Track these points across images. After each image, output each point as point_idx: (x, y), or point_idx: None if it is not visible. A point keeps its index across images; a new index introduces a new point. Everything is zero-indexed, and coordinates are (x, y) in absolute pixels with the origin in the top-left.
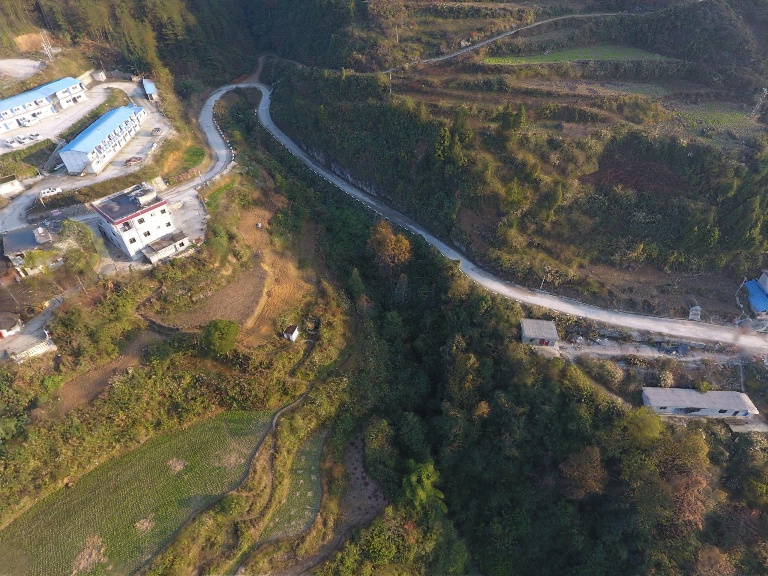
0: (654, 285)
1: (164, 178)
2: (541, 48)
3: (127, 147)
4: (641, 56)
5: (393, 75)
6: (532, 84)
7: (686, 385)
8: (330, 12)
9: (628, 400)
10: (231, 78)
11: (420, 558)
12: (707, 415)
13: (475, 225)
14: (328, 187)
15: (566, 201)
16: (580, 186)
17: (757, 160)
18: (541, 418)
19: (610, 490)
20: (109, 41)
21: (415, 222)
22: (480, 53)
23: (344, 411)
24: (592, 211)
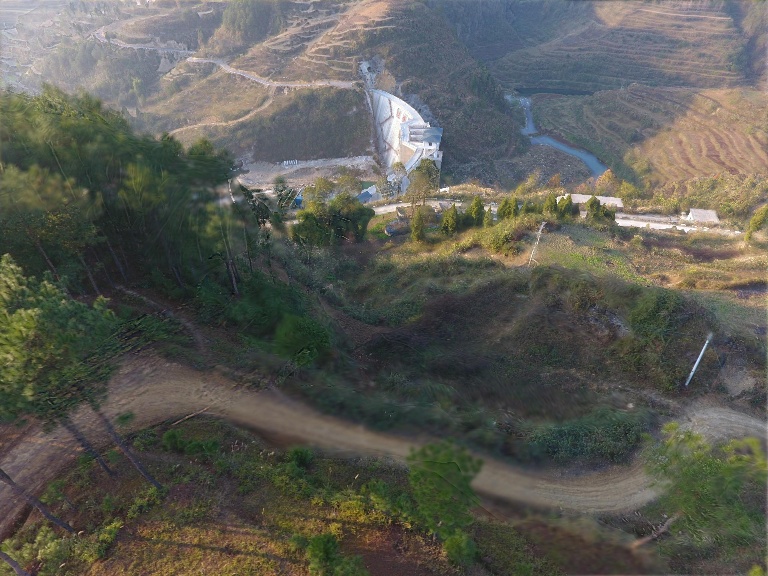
0: None
1: None
2: None
3: None
4: None
5: None
6: None
7: None
8: None
9: None
10: None
11: None
12: None
13: None
14: None
15: None
16: None
17: None
18: None
19: None
20: None
21: None
22: None
23: None
24: None
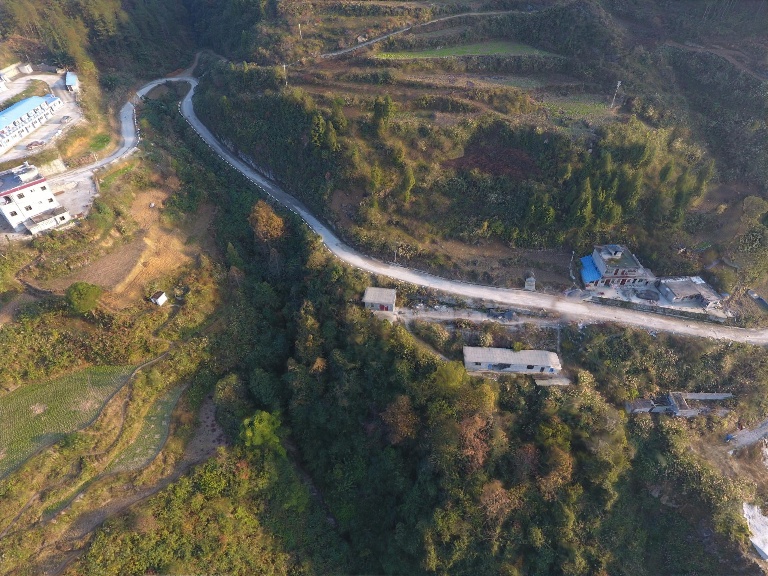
0: (497, 259)
1: (65, 161)
2: (432, 44)
3: (34, 133)
4: None
5: (291, 68)
6: (417, 77)
7: (505, 345)
8: (248, 10)
9: (451, 358)
10: (166, 72)
11: (259, 496)
12: (518, 371)
13: (343, 205)
14: (231, 172)
15: (426, 183)
16: (442, 170)
17: (601, 146)
18: (369, 372)
19: (420, 434)
20: (40, 36)
21: (302, 204)
22: (373, 48)
23: (204, 368)
24: (451, 193)
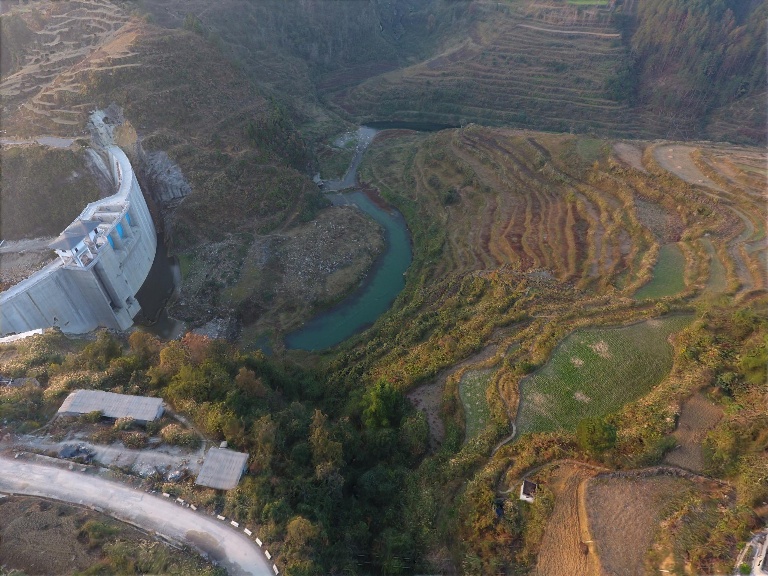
0: (2, 534)
1: None
2: None
3: None
4: None
5: None
6: None
7: (104, 424)
8: None
9: (173, 420)
10: None
11: None
12: None
13: None
14: None
15: None
16: None
17: None
18: None
19: None
20: None
21: None
22: None
23: None
24: None
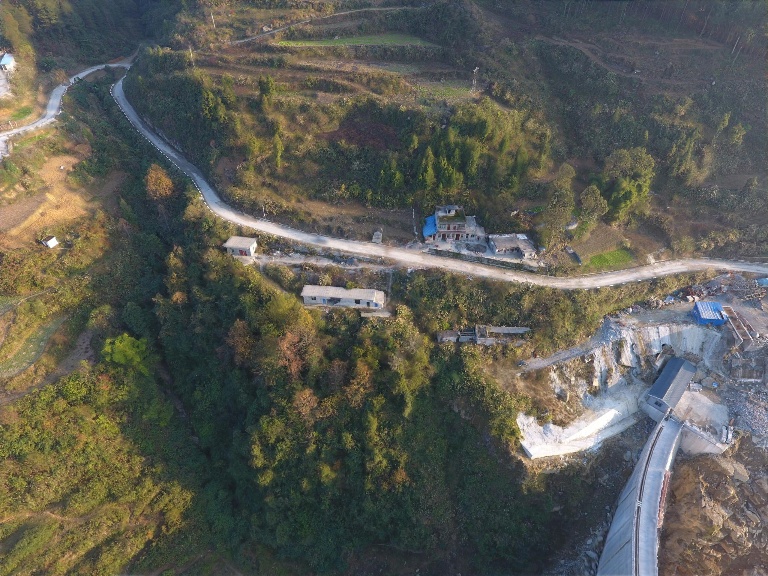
0: (351, 216)
1: None
2: (330, 34)
3: None
4: (412, 43)
5: (200, 53)
6: (309, 62)
7: (342, 285)
8: (175, 2)
9: None
10: (108, 59)
11: (123, 408)
12: (348, 306)
13: (226, 169)
14: (145, 144)
15: (299, 151)
16: (314, 141)
17: (451, 122)
18: (220, 304)
19: None
20: None
21: (200, 171)
22: (275, 37)
23: (87, 302)
24: (321, 160)
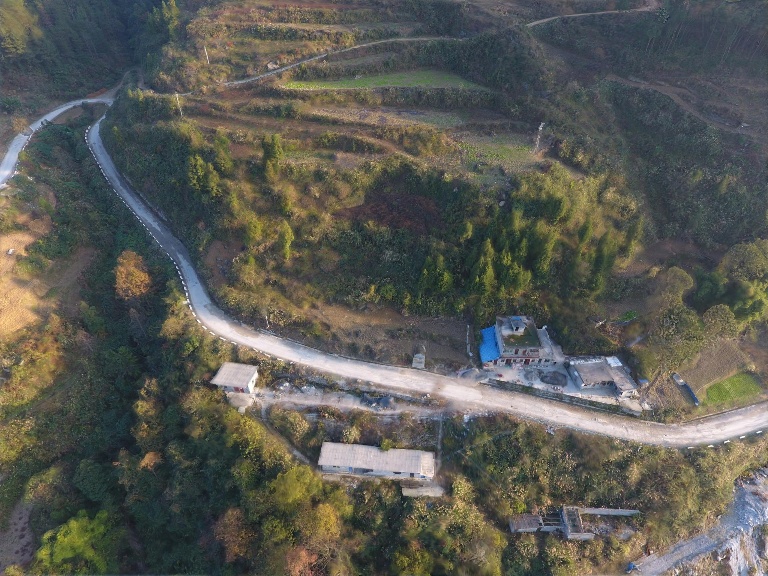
0: (383, 329)
1: None
2: (350, 73)
3: None
4: (451, 83)
5: (190, 97)
6: (325, 110)
7: (375, 441)
8: (163, 29)
9: (309, 455)
10: (87, 92)
11: None
12: (384, 475)
13: (219, 259)
14: (121, 210)
15: (313, 236)
16: (333, 221)
17: (513, 199)
18: (206, 473)
19: None
20: None
21: (187, 251)
22: (283, 77)
23: (28, 455)
24: (342, 247)
